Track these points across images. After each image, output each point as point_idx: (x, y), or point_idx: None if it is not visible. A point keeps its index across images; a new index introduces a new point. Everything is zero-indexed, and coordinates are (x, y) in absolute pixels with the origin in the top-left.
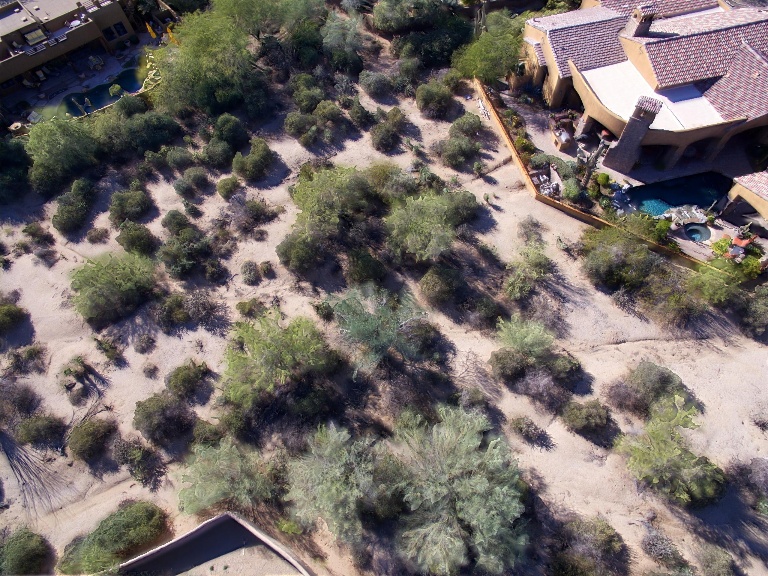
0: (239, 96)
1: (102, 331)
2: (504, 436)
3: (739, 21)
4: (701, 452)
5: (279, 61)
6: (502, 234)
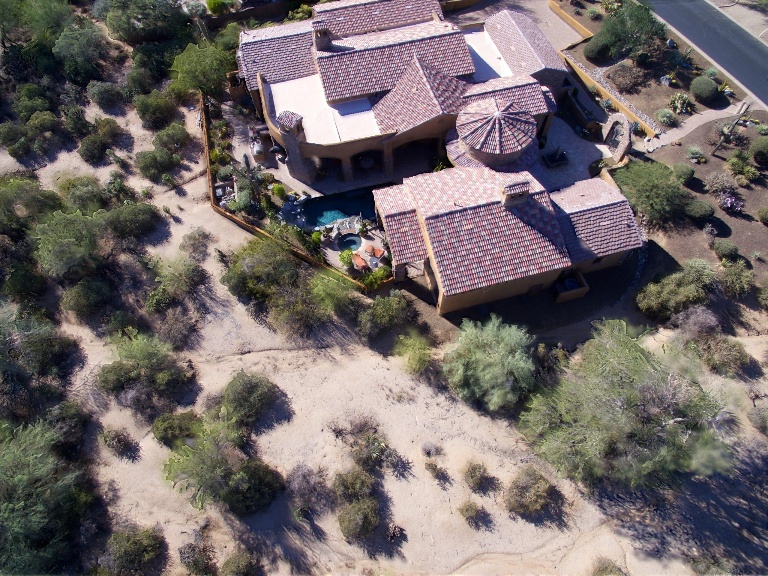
0: None
1: None
2: (97, 449)
3: (418, 36)
4: (272, 460)
5: (21, 70)
6: (171, 246)
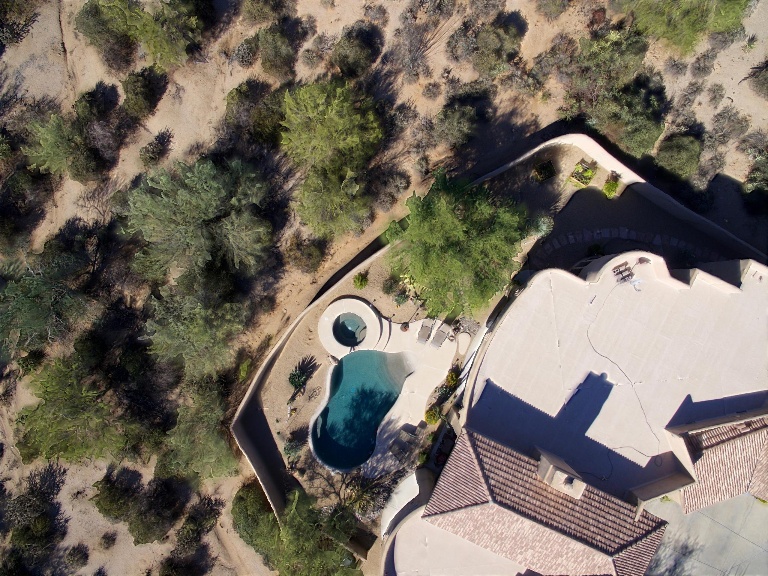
0: None
1: None
2: None
3: None
4: None
5: None
6: None
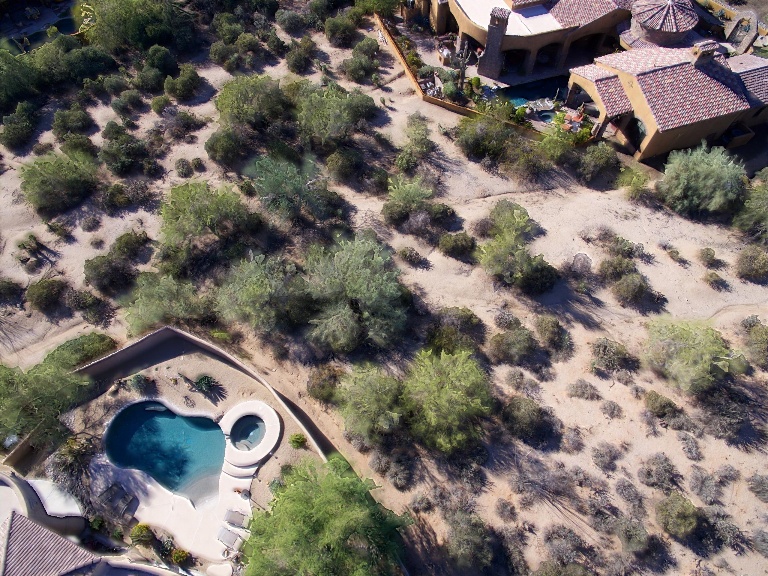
0: (168, 31)
1: (51, 220)
2: (394, 264)
3: None
4: None
5: (204, 6)
6: (396, 127)
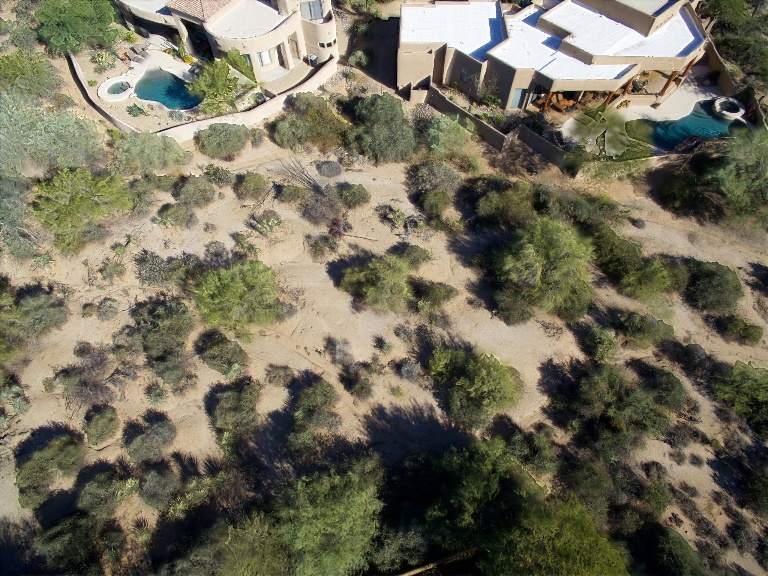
0: None
1: None
2: None
3: None
4: None
5: None
6: None
